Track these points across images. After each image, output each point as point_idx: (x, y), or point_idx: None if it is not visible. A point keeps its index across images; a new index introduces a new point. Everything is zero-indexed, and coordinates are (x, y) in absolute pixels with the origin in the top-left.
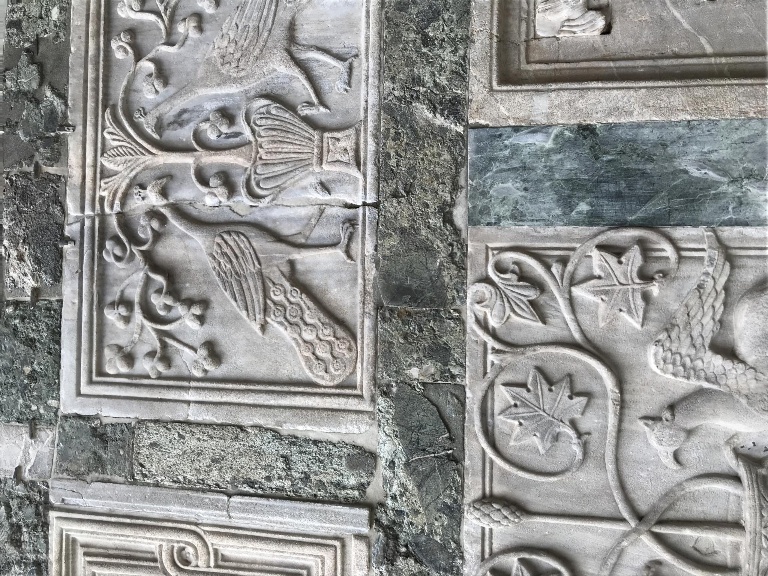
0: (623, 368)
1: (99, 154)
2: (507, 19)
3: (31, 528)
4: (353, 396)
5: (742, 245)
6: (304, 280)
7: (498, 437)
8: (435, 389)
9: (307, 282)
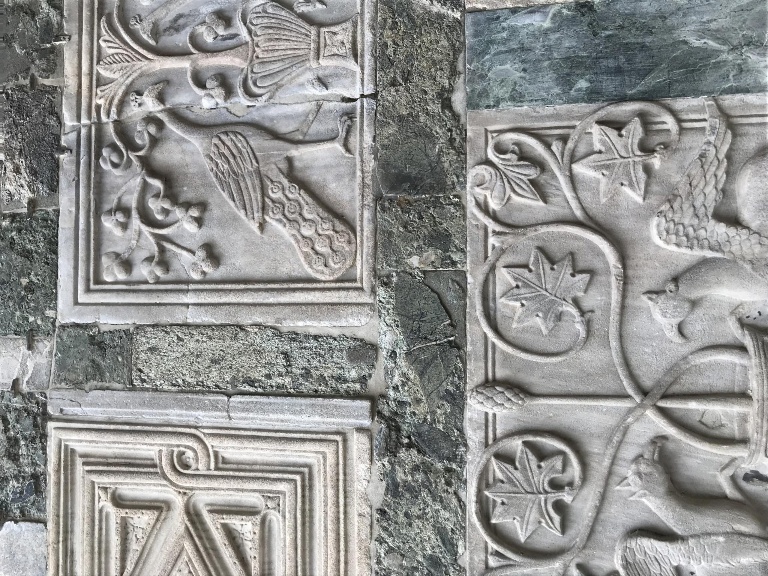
0: (625, 244)
1: (95, 61)
2: None
3: (29, 440)
4: (353, 289)
5: (743, 113)
6: (302, 177)
7: (500, 321)
8: (436, 277)
9: (305, 179)
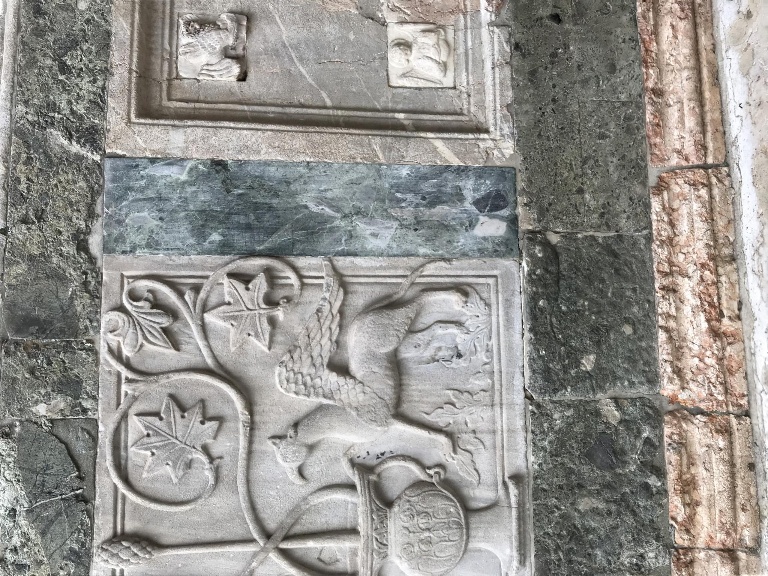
0: (253, 390)
1: None
2: (149, 57)
3: None
4: None
5: (354, 273)
6: None
7: (131, 470)
8: (64, 425)
9: None
